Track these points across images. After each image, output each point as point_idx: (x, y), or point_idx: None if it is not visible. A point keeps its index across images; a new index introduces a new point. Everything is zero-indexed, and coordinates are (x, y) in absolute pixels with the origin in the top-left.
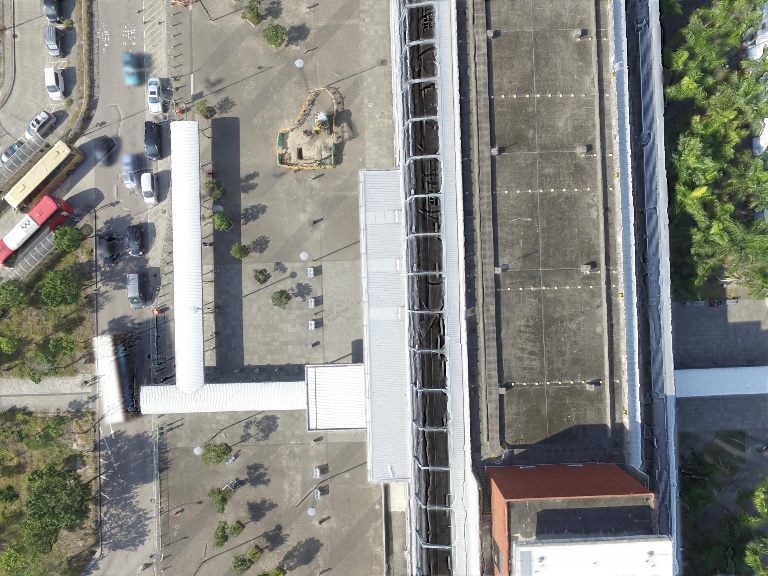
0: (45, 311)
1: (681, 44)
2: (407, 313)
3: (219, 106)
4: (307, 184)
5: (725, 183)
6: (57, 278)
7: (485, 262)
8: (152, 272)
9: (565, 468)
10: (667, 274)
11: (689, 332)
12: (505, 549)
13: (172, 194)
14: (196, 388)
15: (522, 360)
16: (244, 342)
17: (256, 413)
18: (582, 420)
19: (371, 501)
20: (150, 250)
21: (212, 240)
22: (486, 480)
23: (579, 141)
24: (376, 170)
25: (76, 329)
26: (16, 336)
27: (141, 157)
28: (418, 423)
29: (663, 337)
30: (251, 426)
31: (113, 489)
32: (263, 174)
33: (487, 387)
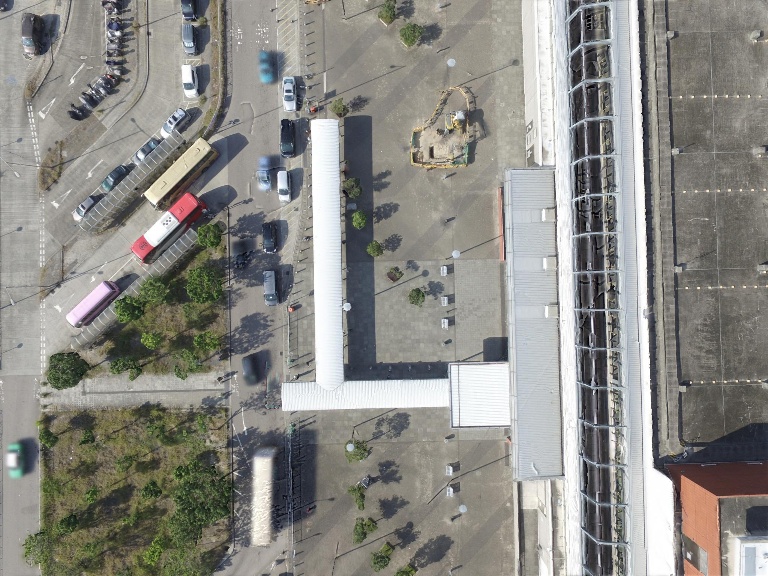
0: (187, 307)
1: None
2: (573, 311)
3: (352, 105)
4: (439, 183)
5: None
6: (204, 275)
7: (665, 261)
8: (285, 269)
9: (746, 466)
10: None
11: None
12: (715, 545)
13: (313, 192)
14: (337, 385)
15: (699, 359)
16: (376, 340)
17: (388, 410)
18: (758, 418)
19: (502, 499)
20: (283, 247)
21: (344, 238)
22: (673, 477)
23: (755, 142)
24: (523, 169)
25: (210, 326)
26: (150, 332)
27: (274, 155)
28: (582, 421)
29: None
30: (383, 423)
31: (246, 485)
32: (395, 173)
33: (667, 385)
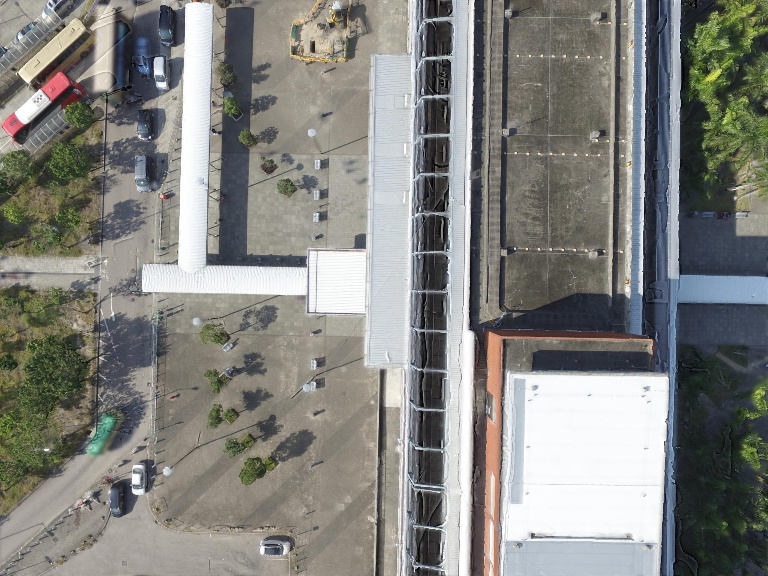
0: (53, 184)
1: None
2: (412, 183)
3: None
4: (318, 77)
5: (740, 81)
6: (66, 149)
7: (493, 123)
8: (160, 158)
9: (564, 332)
10: (677, 157)
11: (696, 244)
12: (499, 387)
13: (184, 75)
14: (198, 268)
15: (525, 225)
16: (248, 231)
17: (256, 302)
18: (583, 289)
19: (366, 396)
20: (159, 136)
21: (221, 129)
22: (483, 336)
23: (594, 8)
24: (388, 54)
25: (82, 210)
26: None
27: (155, 43)
28: (417, 294)
29: (670, 220)
30: (250, 315)
31: (111, 371)
32: (275, 65)
33: (489, 248)
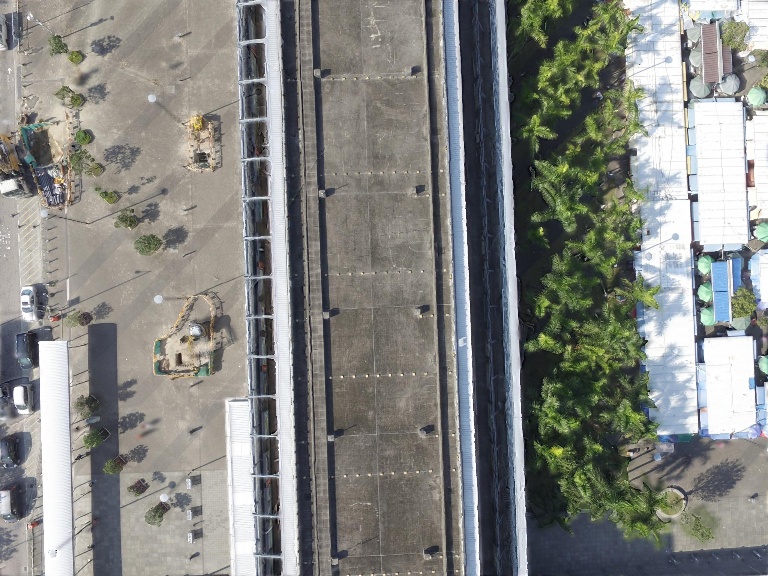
0: None
1: (544, 288)
2: None
3: (96, 312)
4: (186, 391)
5: (597, 415)
6: None
7: (321, 552)
8: (28, 482)
9: None
10: (524, 535)
11: (577, 539)
12: None
13: (41, 415)
14: None
15: None
16: (122, 554)
17: None
18: None
19: None
20: (26, 460)
21: (89, 449)
22: None
23: (420, 421)
24: (242, 401)
25: None
26: None
27: (16, 365)
28: None
29: None
30: None
31: None
32: (141, 381)
33: None
